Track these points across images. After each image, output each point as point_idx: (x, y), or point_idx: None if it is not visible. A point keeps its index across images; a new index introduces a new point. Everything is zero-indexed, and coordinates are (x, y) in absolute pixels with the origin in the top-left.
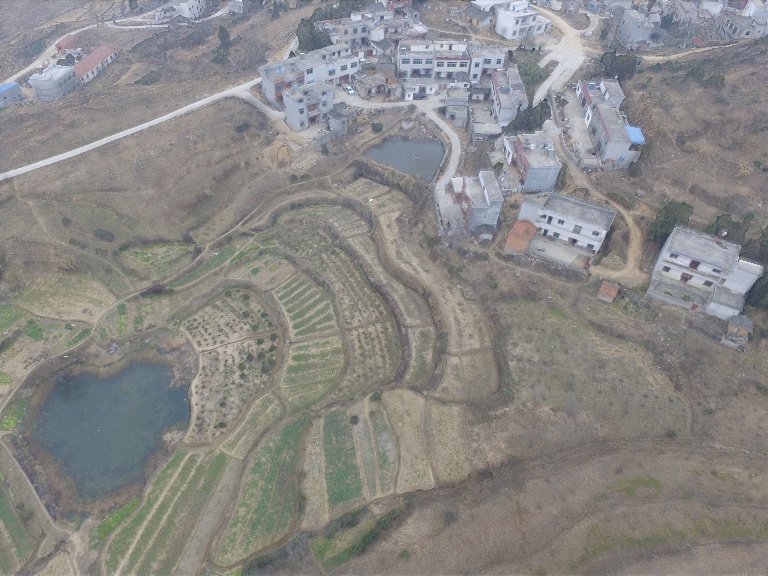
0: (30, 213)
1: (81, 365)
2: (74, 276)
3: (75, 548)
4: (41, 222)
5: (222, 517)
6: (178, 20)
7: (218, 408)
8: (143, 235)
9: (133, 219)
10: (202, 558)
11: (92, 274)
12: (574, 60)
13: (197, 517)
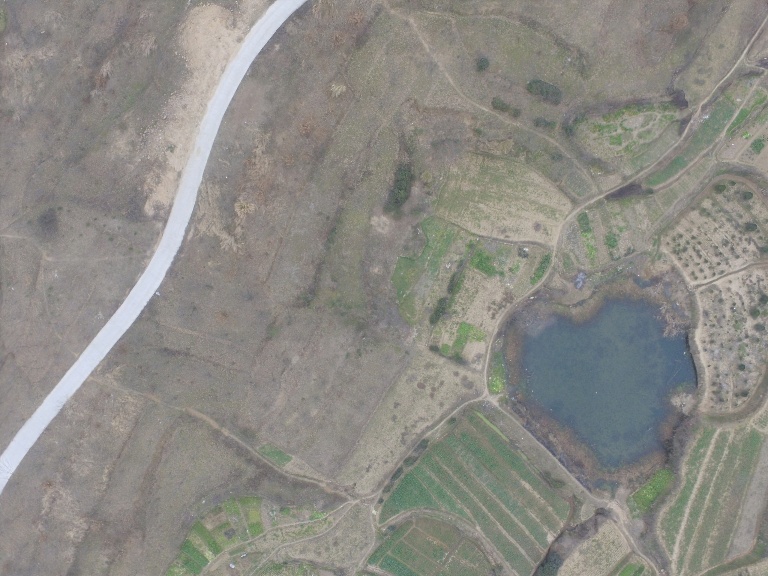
0: (419, 45)
1: (546, 304)
2: (501, 162)
3: (619, 517)
4: (441, 65)
5: (766, 498)
6: None
7: (734, 370)
8: (608, 91)
9: (590, 57)
10: (753, 535)
11: (528, 159)
12: None
13: (741, 497)
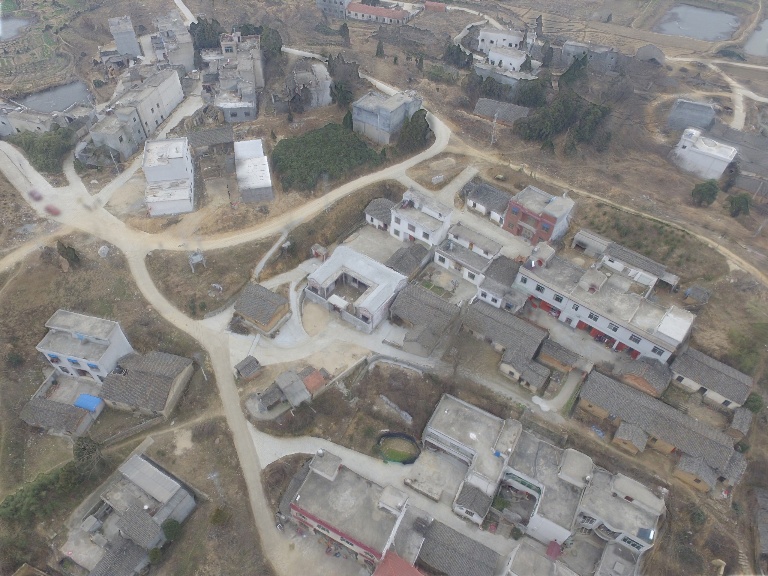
0: None
1: None
2: None
3: None
4: None
5: None
6: (470, 41)
7: None
8: None
9: None
10: None
11: None
12: (45, 201)
13: None
